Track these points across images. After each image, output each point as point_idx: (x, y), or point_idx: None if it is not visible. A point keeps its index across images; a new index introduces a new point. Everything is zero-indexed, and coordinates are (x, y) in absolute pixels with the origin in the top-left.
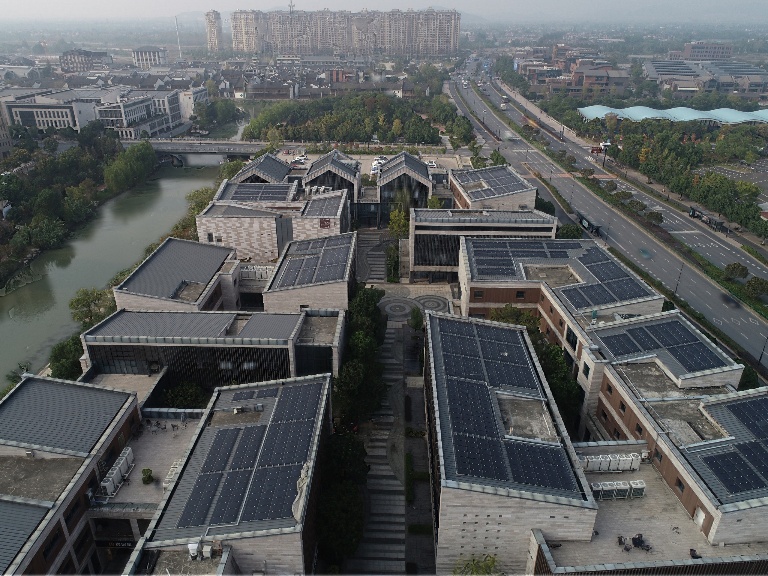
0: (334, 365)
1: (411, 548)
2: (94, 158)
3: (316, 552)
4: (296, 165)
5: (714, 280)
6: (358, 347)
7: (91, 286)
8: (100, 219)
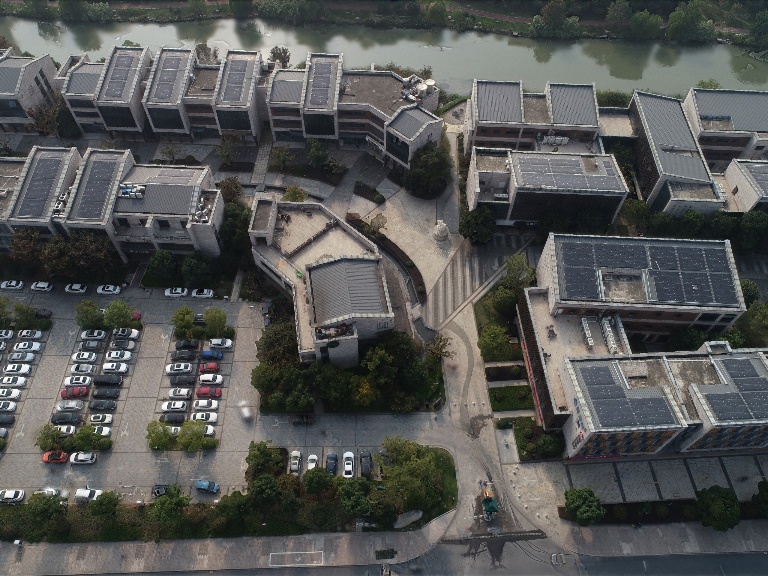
0: (665, 208)
1: None
2: None
3: (537, 222)
4: None
5: None
6: None
7: None
8: None
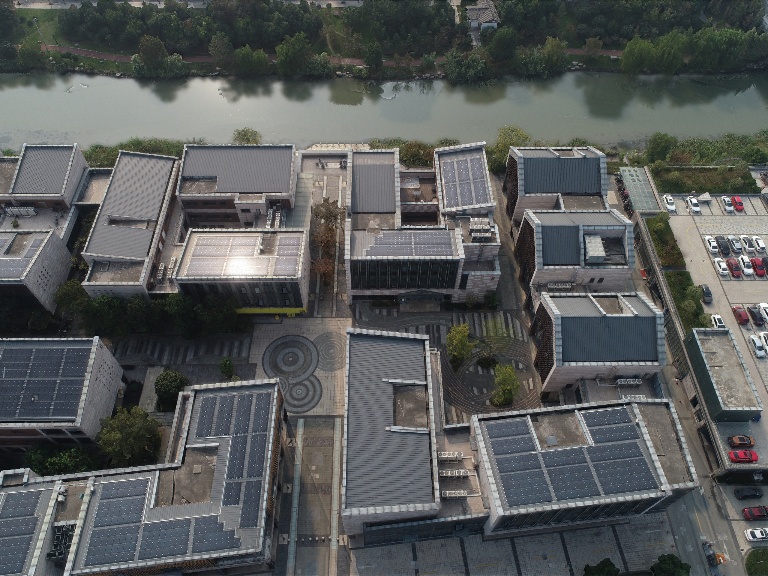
0: None
1: None
2: (671, 17)
3: None
4: (762, 203)
5: None
6: None
7: (375, 131)
8: (537, 84)
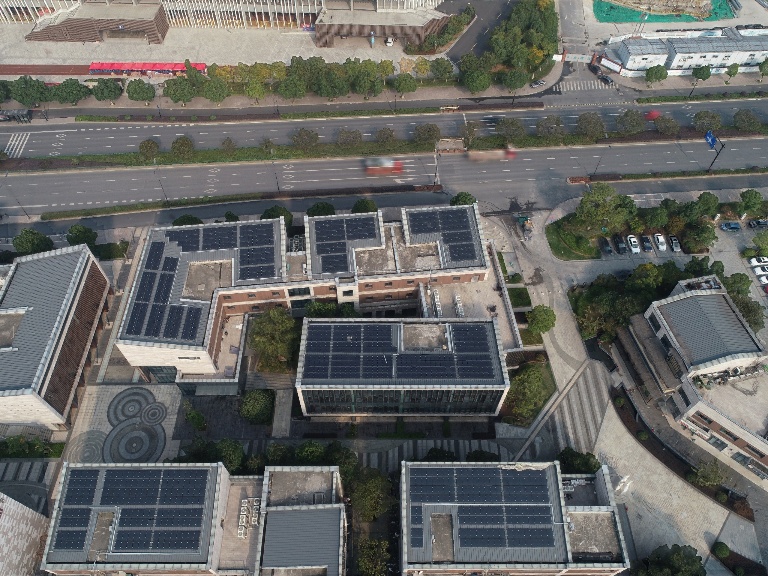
0: None
1: (461, 436)
2: None
3: None
4: None
5: (142, 166)
6: (318, 455)
7: None
8: None
